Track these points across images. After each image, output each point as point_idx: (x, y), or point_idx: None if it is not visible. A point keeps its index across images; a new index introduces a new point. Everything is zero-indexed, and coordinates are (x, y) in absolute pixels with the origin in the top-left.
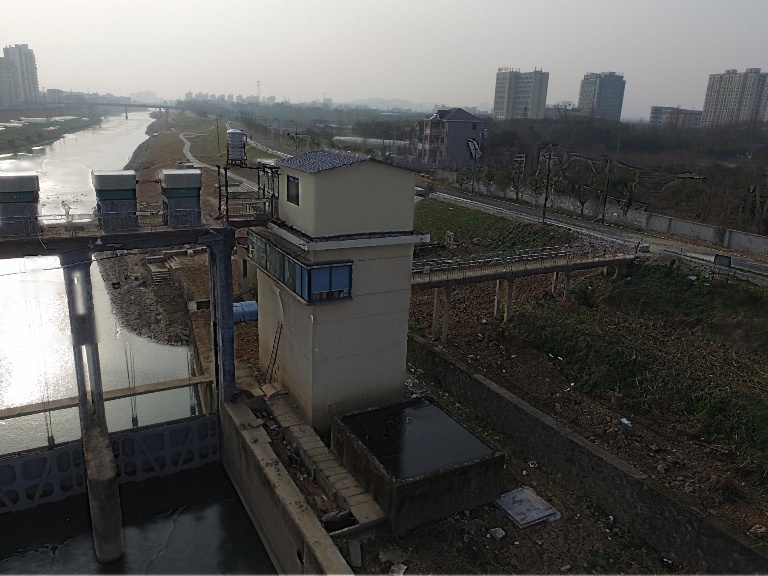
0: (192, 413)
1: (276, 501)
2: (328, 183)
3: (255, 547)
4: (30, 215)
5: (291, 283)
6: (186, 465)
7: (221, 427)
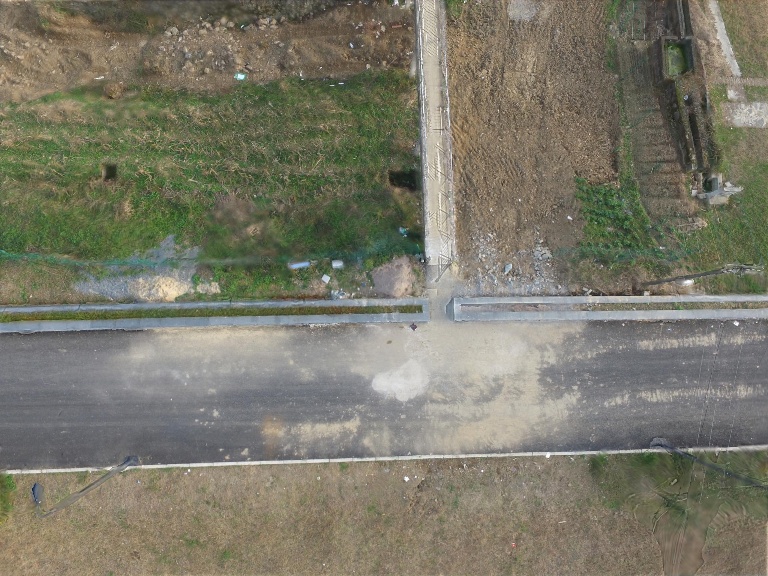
0: None
1: None
2: None
3: None
4: None
5: None
6: None
7: None
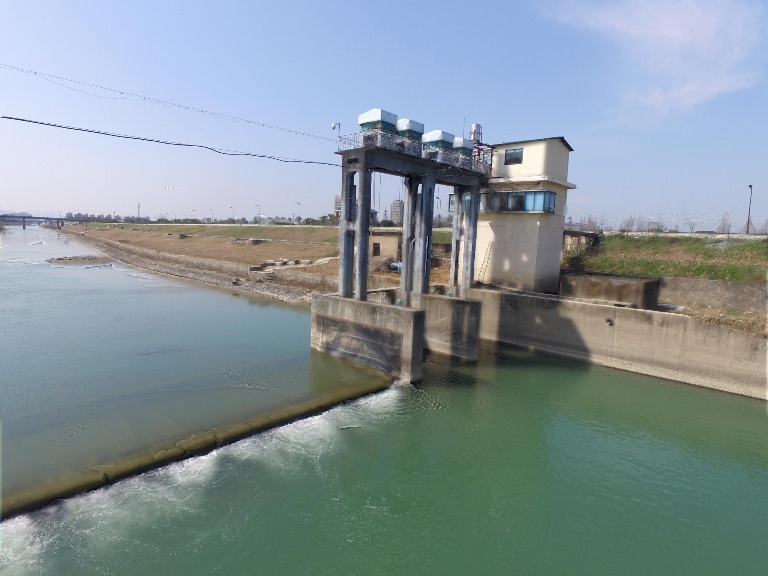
0: None
1: (570, 308)
2: (548, 147)
3: None
4: (419, 147)
5: (516, 209)
6: None
7: None
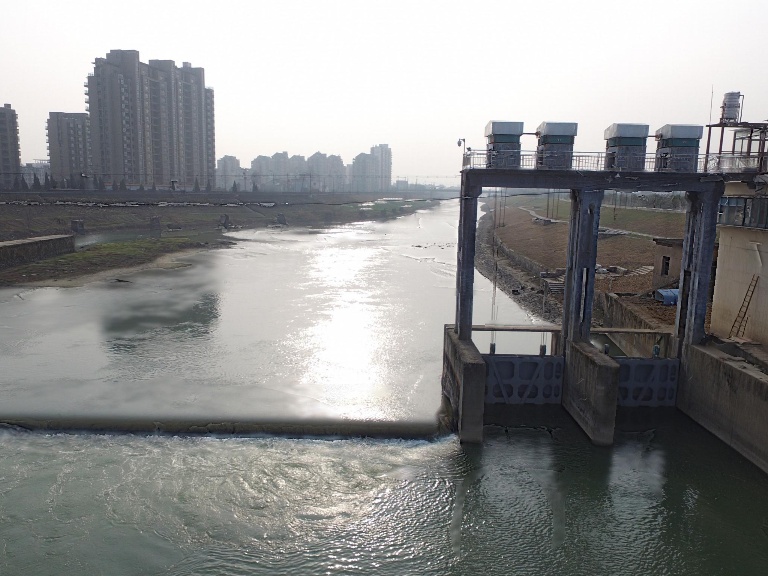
0: (657, 352)
1: None
2: None
3: (742, 468)
4: None
5: None
6: (644, 402)
7: (683, 371)
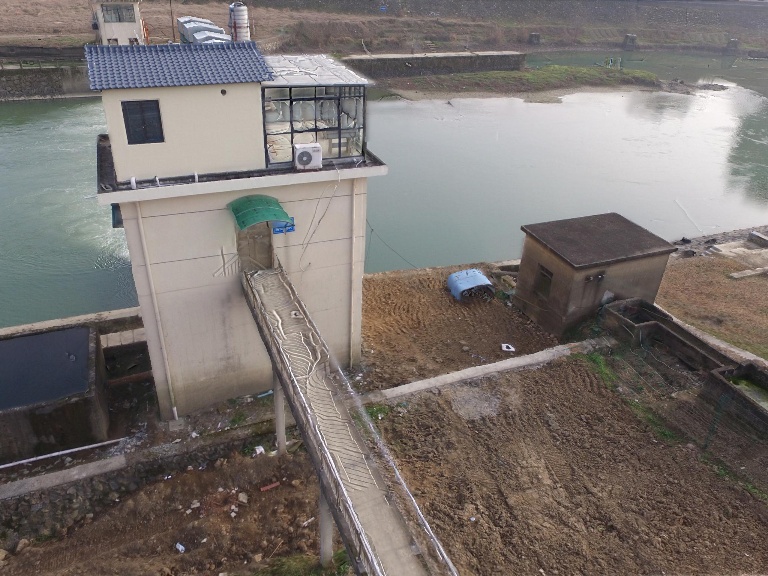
0: None
1: None
2: None
3: None
4: None
5: None
6: None
7: None
